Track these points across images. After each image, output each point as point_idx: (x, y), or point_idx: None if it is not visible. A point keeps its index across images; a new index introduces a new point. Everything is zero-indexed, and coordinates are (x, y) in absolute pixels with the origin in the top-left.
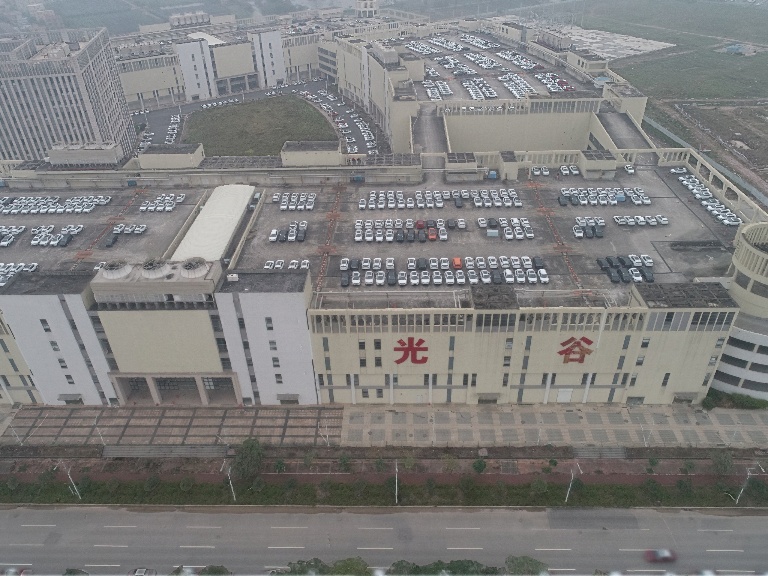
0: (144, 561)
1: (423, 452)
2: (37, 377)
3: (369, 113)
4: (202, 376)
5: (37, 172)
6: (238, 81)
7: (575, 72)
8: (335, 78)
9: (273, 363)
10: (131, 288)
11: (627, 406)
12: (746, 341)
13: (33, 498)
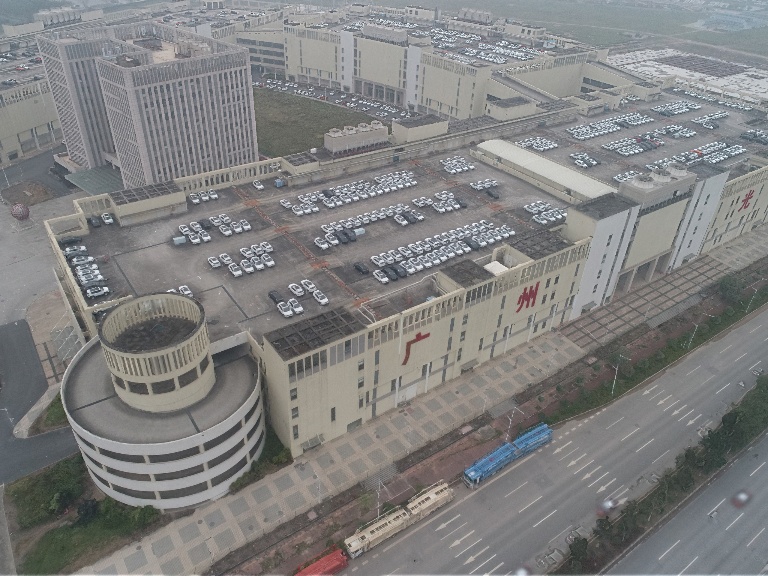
0: (765, 353)
1: None
2: (578, 294)
3: (354, 92)
4: None
5: (325, 162)
6: None
7: (521, 39)
8: (264, 68)
9: (693, 232)
10: (663, 191)
11: None
12: None
13: (667, 361)
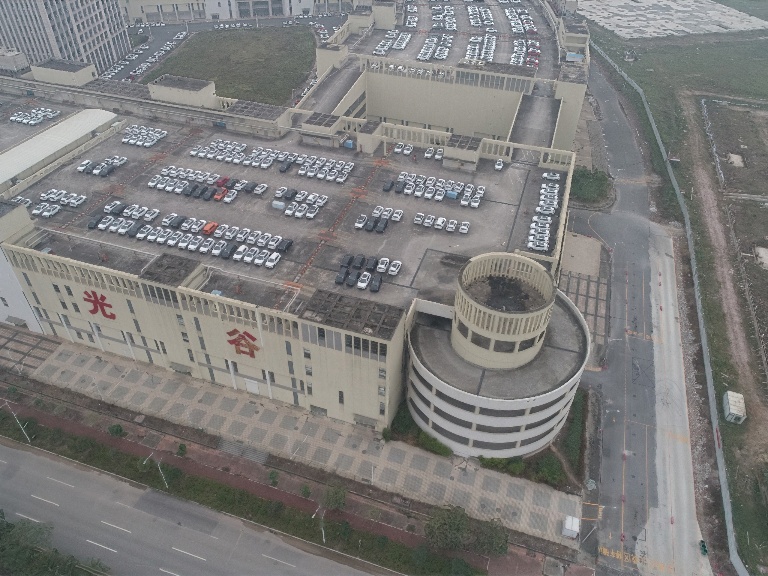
0: None
1: (90, 403)
2: None
3: None
4: None
5: None
6: (263, 5)
7: (557, 43)
8: None
9: None
10: None
11: (310, 414)
12: (425, 379)
13: None
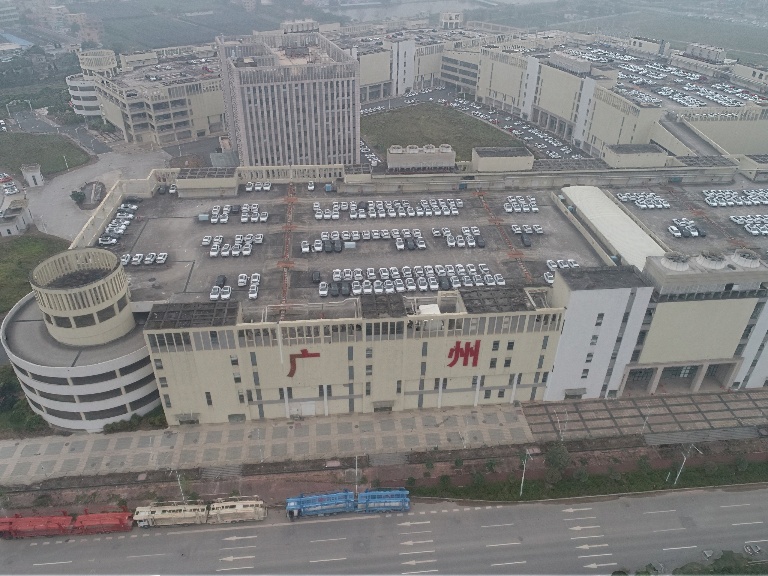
0: None
1: None
2: (555, 373)
3: (530, 120)
4: (711, 363)
5: (376, 176)
6: (372, 89)
7: (749, 83)
8: (462, 87)
9: None
10: (700, 279)
11: None
12: None
13: (629, 487)
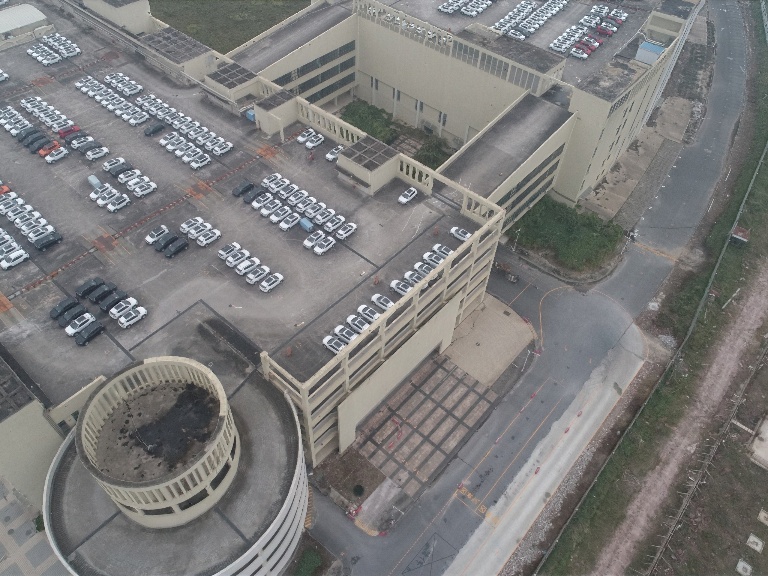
0: None
1: None
2: None
3: None
4: None
5: None
6: None
7: None
8: None
9: None
10: None
11: None
12: None
13: None
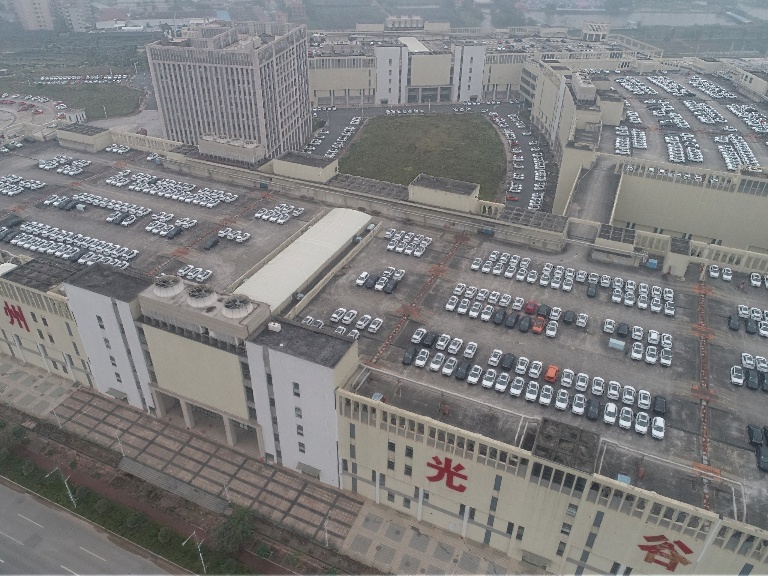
0: None
1: None
2: (93, 366)
3: (553, 149)
4: (229, 417)
5: (186, 158)
6: (431, 91)
7: None
8: None
9: (297, 430)
10: (172, 311)
11: None
12: None
13: (40, 489)
